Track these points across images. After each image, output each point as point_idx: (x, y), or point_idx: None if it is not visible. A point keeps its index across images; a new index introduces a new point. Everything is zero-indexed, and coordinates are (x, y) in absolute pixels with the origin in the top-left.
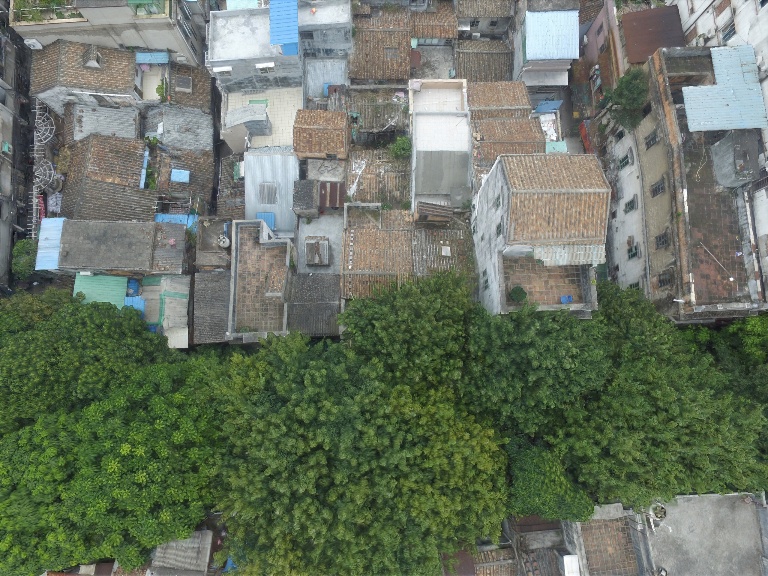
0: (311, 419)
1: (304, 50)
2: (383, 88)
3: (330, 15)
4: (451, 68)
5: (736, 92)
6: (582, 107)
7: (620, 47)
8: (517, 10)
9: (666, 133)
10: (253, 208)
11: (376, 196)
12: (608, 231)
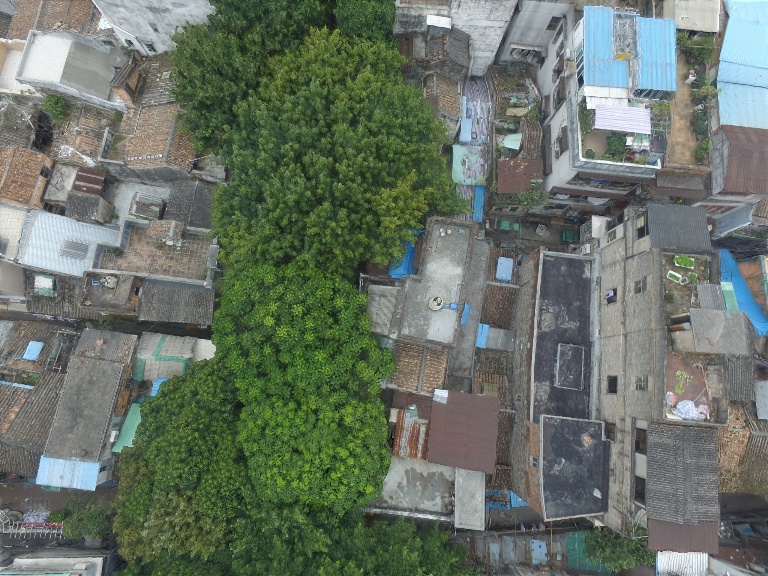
0: (273, 160)
1: None
2: None
3: None
4: None
5: None
6: None
7: None
8: None
9: None
10: None
11: None
12: None
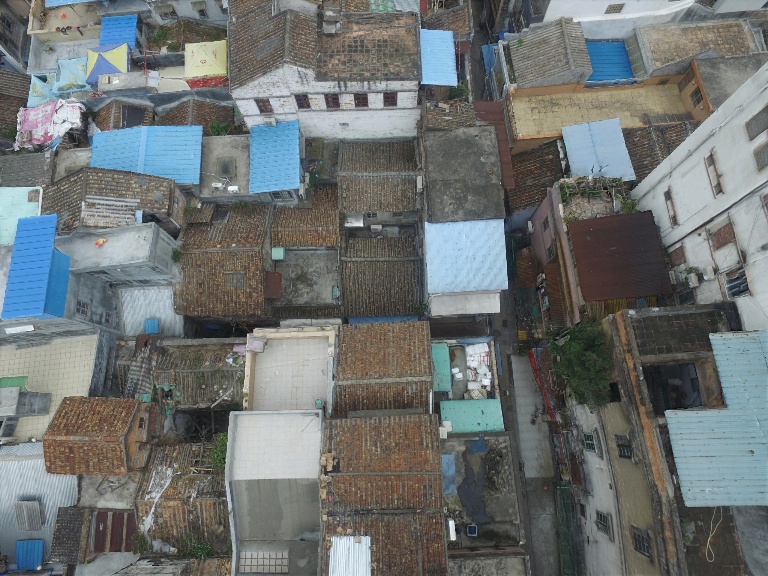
0: None
1: (107, 282)
2: (211, 344)
3: (126, 247)
4: (334, 284)
5: (765, 425)
6: (530, 324)
7: (571, 266)
8: (422, 206)
9: (646, 461)
10: (12, 532)
11: (186, 531)
12: (576, 532)
